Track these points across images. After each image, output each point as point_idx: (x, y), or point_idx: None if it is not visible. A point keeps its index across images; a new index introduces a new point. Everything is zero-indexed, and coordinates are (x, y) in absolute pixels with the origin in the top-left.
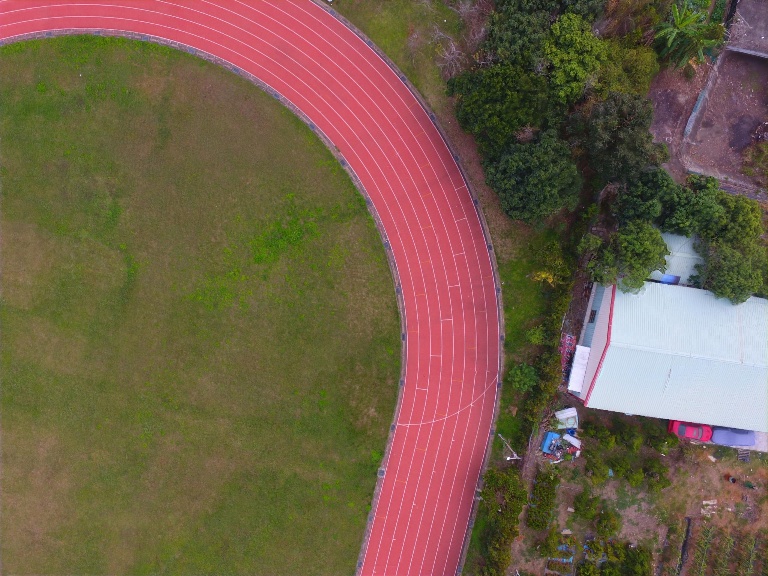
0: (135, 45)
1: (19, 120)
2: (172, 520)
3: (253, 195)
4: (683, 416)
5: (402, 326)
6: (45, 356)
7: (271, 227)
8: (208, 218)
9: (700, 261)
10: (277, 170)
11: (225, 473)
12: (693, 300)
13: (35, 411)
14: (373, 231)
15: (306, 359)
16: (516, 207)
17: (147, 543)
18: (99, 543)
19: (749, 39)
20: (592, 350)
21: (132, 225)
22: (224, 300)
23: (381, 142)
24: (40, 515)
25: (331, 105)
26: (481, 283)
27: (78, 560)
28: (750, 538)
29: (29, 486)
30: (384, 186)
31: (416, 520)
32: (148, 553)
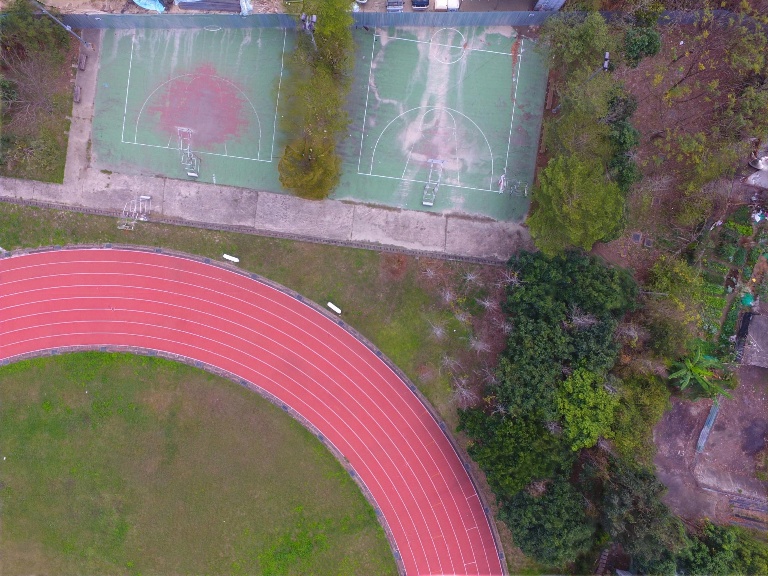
0: (142, 361)
1: (24, 439)
2: None
3: (261, 509)
4: None
5: None
6: None
7: (280, 540)
8: (216, 533)
9: None
10: (286, 483)
11: None
12: None
13: None
14: (383, 542)
15: None
16: None
17: None
18: None
19: (761, 355)
20: None
21: (139, 542)
22: None
23: (391, 452)
24: None
25: (340, 416)
26: None
27: None
28: None
29: None
30: (394, 496)
31: None
32: None
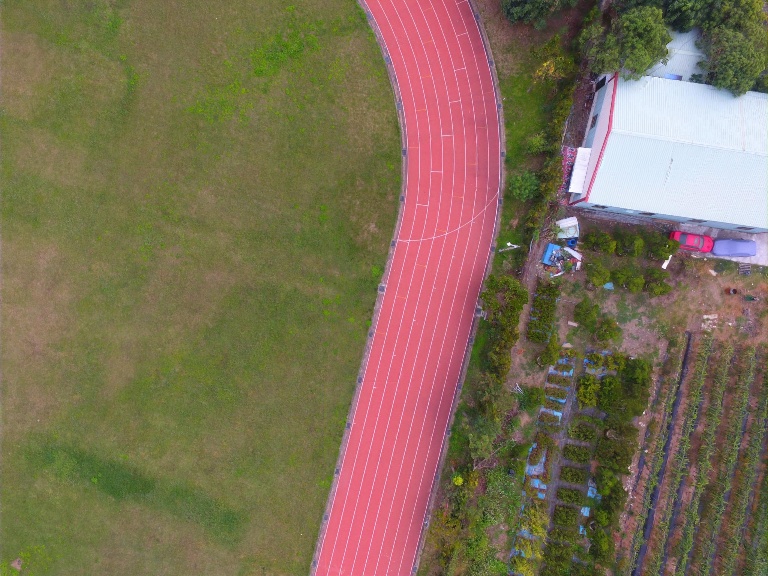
0: None
1: None
2: (172, 333)
3: (253, 7)
4: (684, 211)
5: (403, 141)
6: (45, 167)
7: (271, 40)
8: (208, 30)
9: (702, 58)
10: None
11: (225, 287)
12: (695, 93)
13: (35, 222)
14: (374, 45)
15: (306, 173)
16: (517, 2)
17: (147, 355)
18: (99, 355)
19: None
20: (593, 149)
21: (132, 36)
22: (224, 113)
23: None
24: (40, 326)
25: None
26: (482, 99)
27: (78, 371)
28: None
29: (29, 297)
30: None
31: (416, 336)
32: (148, 366)
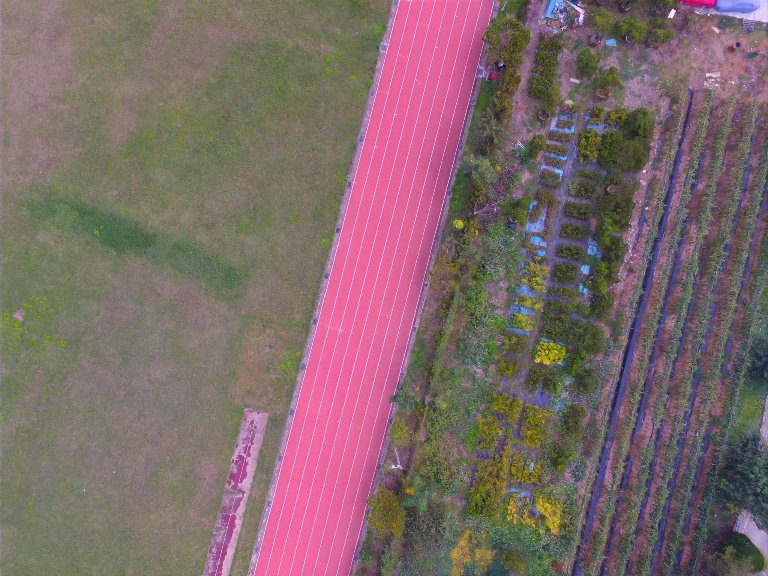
0: None
1: None
2: (174, 88)
3: None
4: None
5: None
6: None
7: None
8: None
9: None
10: None
11: (227, 42)
12: None
13: None
14: None
15: None
16: None
17: (149, 110)
18: (101, 108)
19: None
20: None
21: None
22: None
23: None
24: (43, 78)
25: None
26: None
27: (80, 124)
28: None
29: (32, 48)
30: None
31: (418, 96)
32: (150, 120)
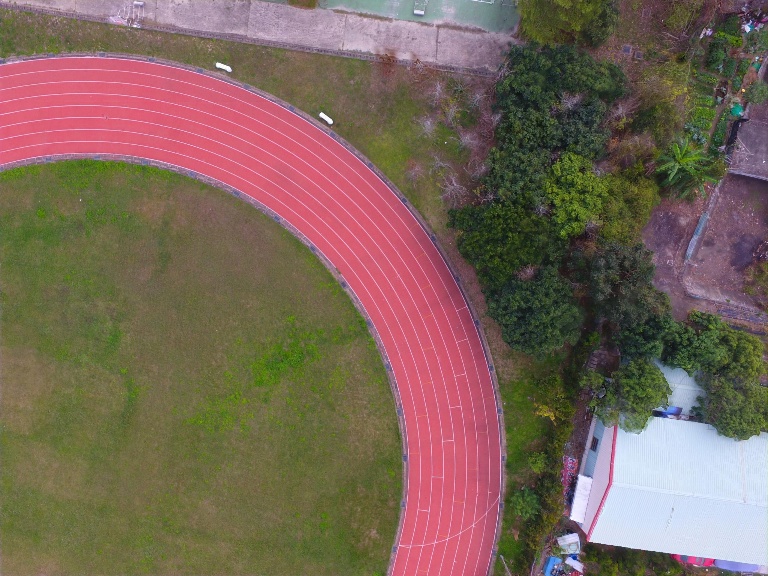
0: (135, 169)
1: (19, 246)
2: None
3: (254, 318)
4: (686, 551)
5: (403, 447)
6: (46, 481)
7: (272, 350)
8: (209, 341)
9: (702, 393)
10: (278, 293)
11: None
12: (695, 435)
13: (36, 537)
14: (374, 353)
15: (307, 481)
16: (517, 341)
17: None
18: None
19: (750, 163)
20: (594, 482)
21: (133, 349)
22: (225, 423)
23: (382, 264)
24: None
25: (332, 227)
26: (482, 404)
27: None
28: None
29: None
30: (385, 308)
31: None
32: None
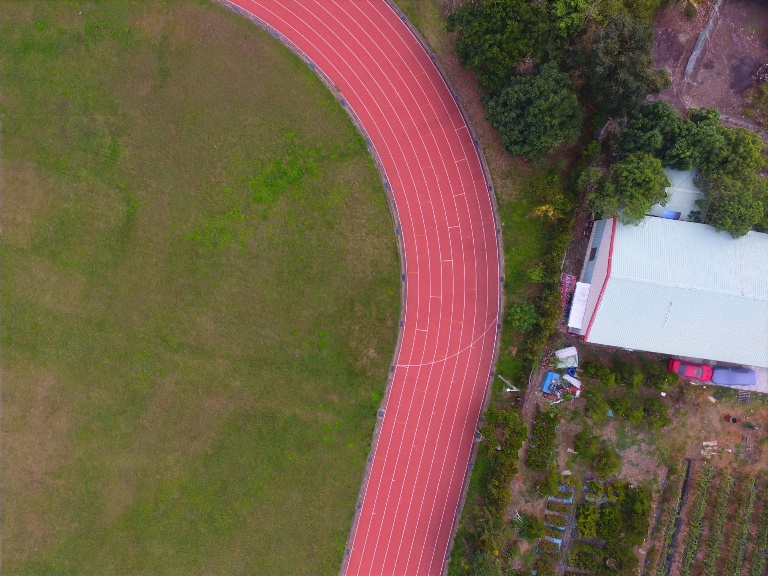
0: None
1: (18, 58)
2: (171, 460)
3: (253, 134)
4: (683, 351)
5: (402, 267)
6: (44, 295)
7: (271, 167)
8: (207, 157)
9: (701, 196)
10: (277, 109)
11: (224, 413)
12: (694, 234)
13: (34, 350)
14: (373, 171)
15: (305, 299)
16: (516, 141)
17: (146, 483)
18: (98, 483)
19: None
20: (592, 286)
21: (131, 164)
22: (223, 240)
23: (381, 82)
24: (39, 454)
25: (331, 45)
26: (481, 224)
27: (77, 500)
28: (750, 479)
29: (28, 425)
30: (384, 126)
31: (415, 461)
32: (147, 493)
